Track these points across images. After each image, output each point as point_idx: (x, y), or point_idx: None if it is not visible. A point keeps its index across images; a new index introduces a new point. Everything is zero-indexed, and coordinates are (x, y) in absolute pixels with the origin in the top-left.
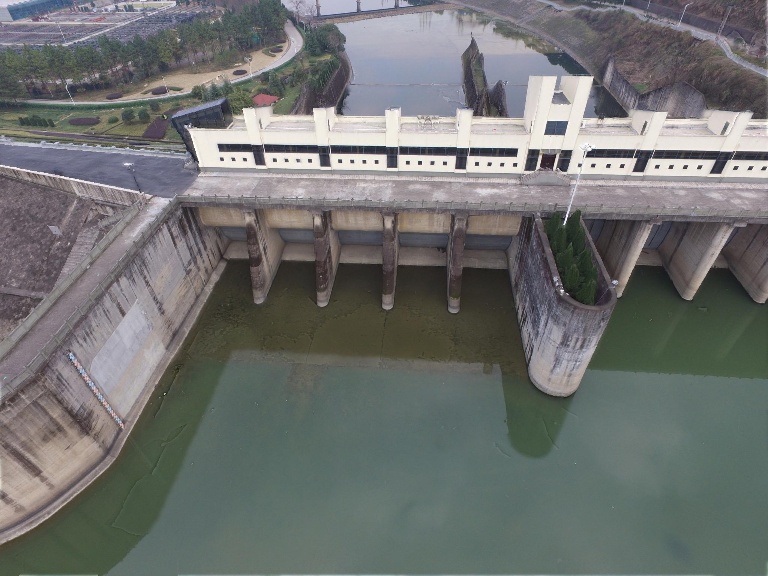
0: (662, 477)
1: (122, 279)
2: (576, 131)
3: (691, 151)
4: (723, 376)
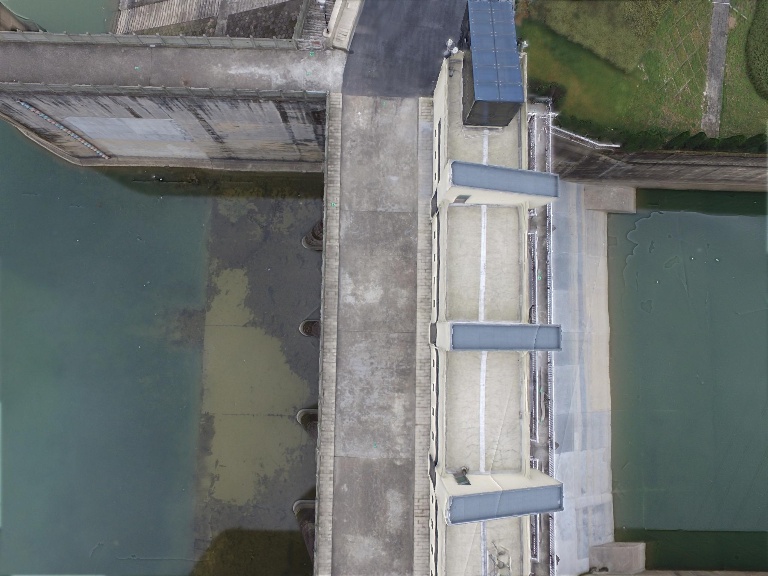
0: None
1: (144, 99)
2: None
3: None
4: None
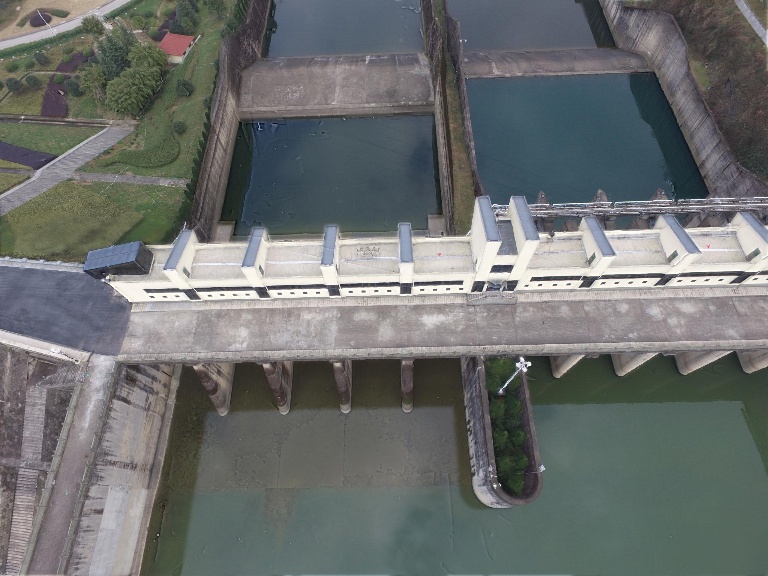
0: None
1: (91, 490)
2: (522, 270)
3: (637, 274)
4: None
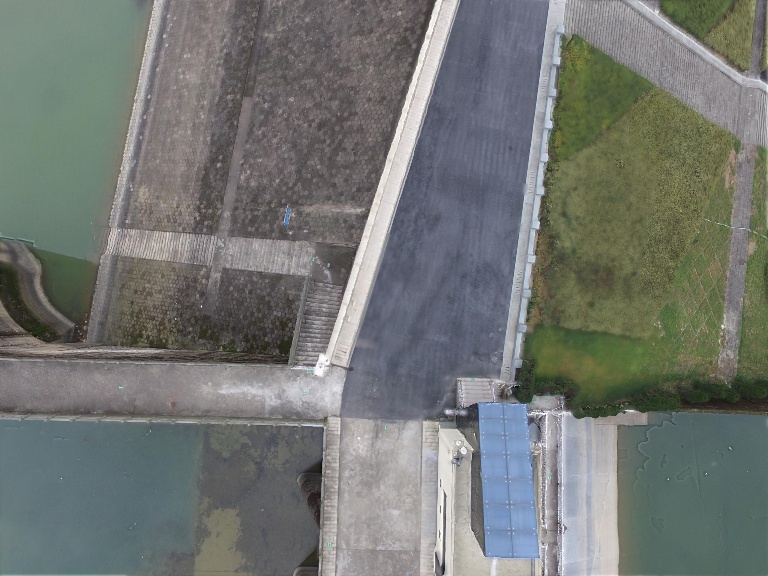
0: None
1: None
2: None
3: None
4: None
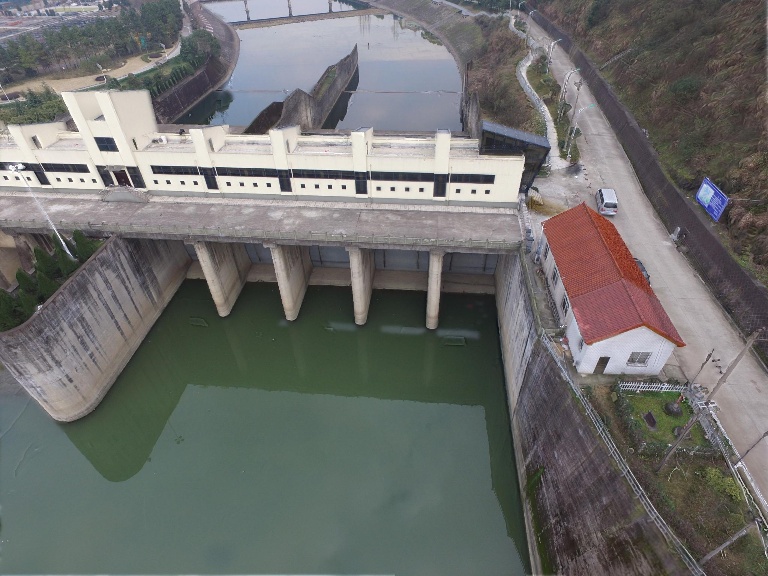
0: (90, 509)
1: None
2: (127, 148)
3: (250, 169)
4: (373, 397)
